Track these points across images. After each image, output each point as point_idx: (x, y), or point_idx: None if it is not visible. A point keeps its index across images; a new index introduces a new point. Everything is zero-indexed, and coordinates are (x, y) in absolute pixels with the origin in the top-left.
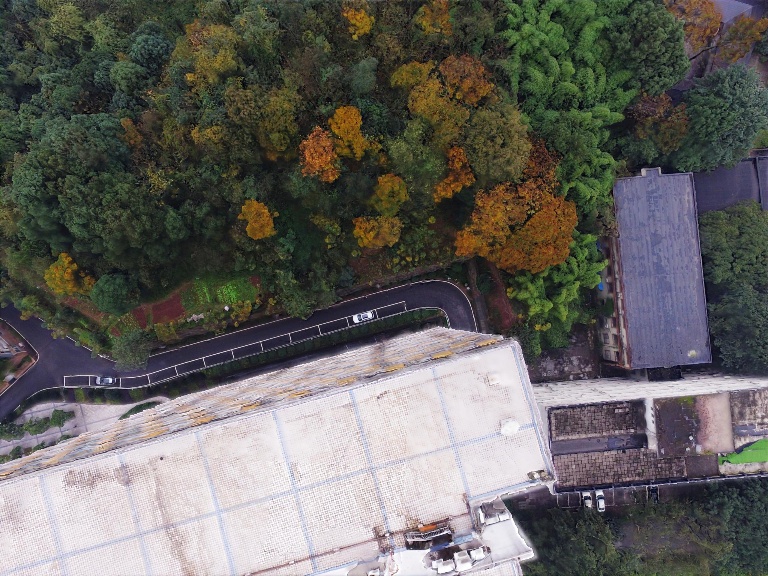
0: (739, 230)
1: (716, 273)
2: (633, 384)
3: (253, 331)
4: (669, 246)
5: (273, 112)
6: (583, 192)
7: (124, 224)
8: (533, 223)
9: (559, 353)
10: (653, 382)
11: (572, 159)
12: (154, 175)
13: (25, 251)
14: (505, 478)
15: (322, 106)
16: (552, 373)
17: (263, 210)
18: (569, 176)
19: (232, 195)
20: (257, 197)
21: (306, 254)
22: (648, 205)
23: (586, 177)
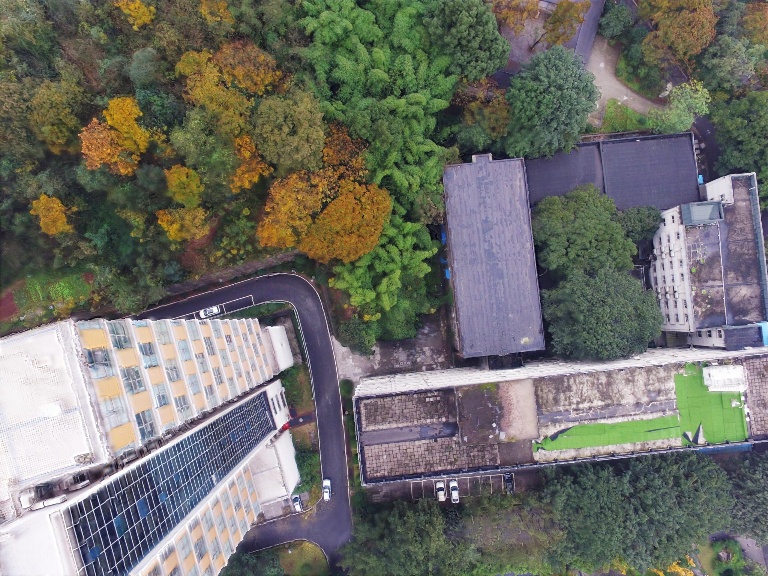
0: (574, 215)
1: (550, 259)
2: (470, 373)
3: None
4: (501, 233)
5: (40, 105)
6: (398, 180)
7: None
8: (329, 211)
9: (411, 344)
10: (492, 371)
11: (380, 146)
12: None
13: None
14: (52, 462)
15: (98, 98)
16: (405, 364)
17: (52, 205)
18: (384, 164)
19: (27, 190)
20: (54, 192)
21: (128, 249)
22: (479, 192)
23: (408, 165)
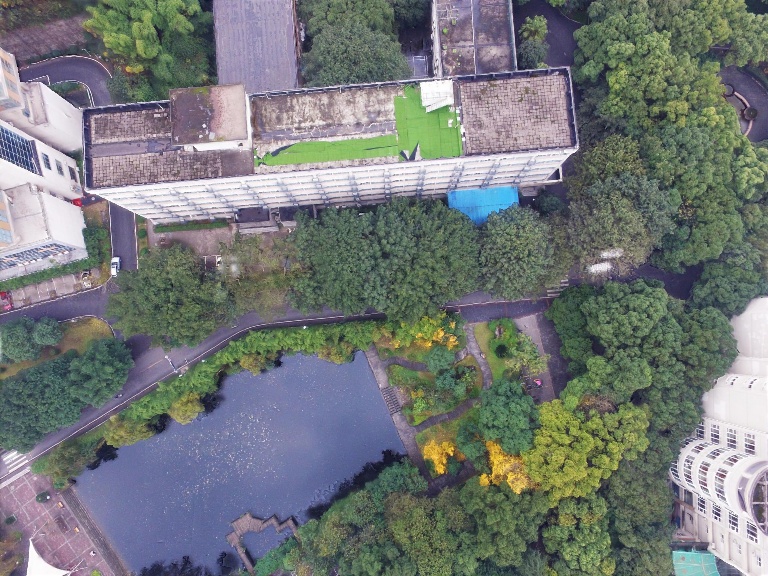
0: None
1: (309, 21)
2: None
3: None
4: None
5: None
6: None
7: None
8: None
9: None
10: None
11: None
12: None
13: None
14: None
15: None
16: None
17: None
18: None
19: None
20: None
21: None
22: None
23: None
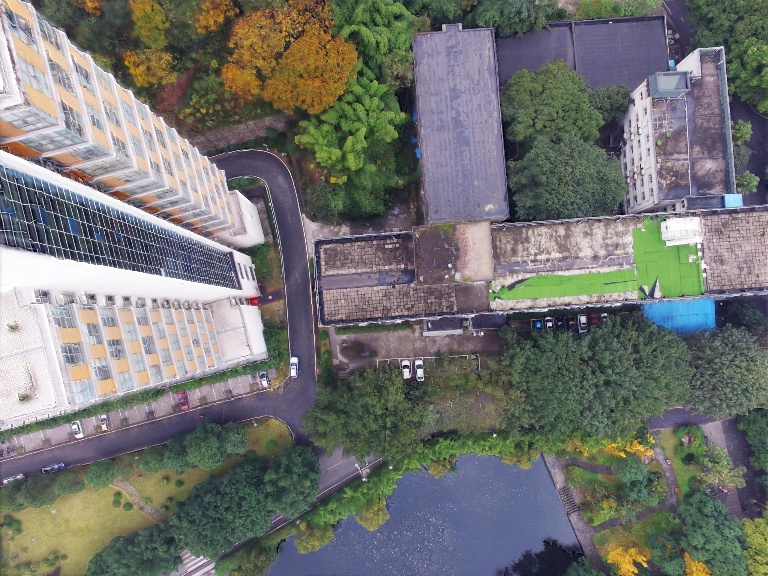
0: (543, 87)
1: (517, 129)
2: None
3: None
4: (468, 101)
5: None
6: (365, 36)
7: None
8: (292, 51)
9: (381, 224)
10: None
11: None
12: None
13: None
14: None
15: None
16: None
17: None
18: (351, 19)
19: None
20: None
21: None
22: (448, 60)
23: (377, 26)
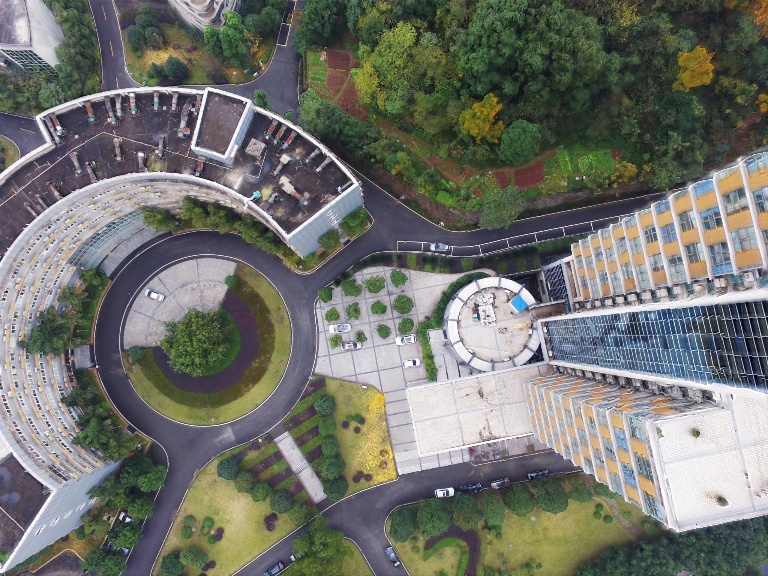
0: None
1: None
2: None
3: (584, 211)
4: None
5: None
6: None
7: (594, 54)
8: None
9: None
10: None
11: None
12: (627, 10)
13: (444, 93)
14: None
15: None
16: None
17: (708, 57)
18: None
19: (666, 46)
20: (687, 50)
21: (686, 124)
22: None
23: None
